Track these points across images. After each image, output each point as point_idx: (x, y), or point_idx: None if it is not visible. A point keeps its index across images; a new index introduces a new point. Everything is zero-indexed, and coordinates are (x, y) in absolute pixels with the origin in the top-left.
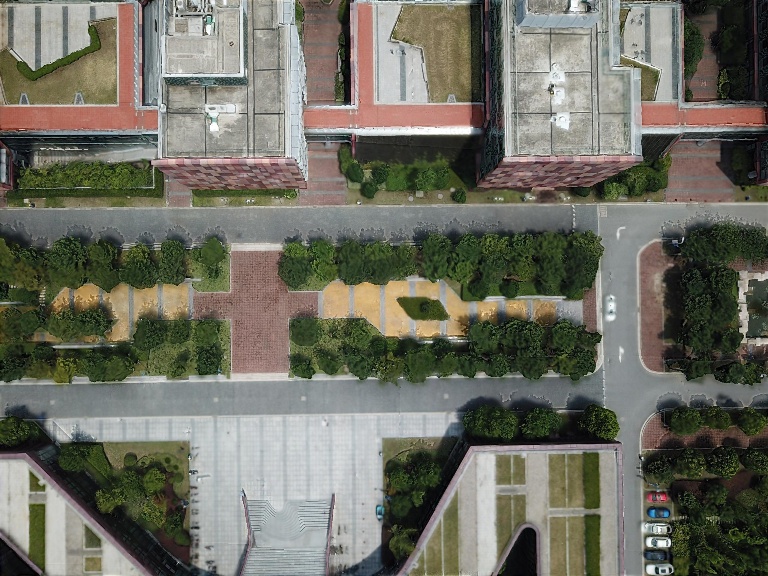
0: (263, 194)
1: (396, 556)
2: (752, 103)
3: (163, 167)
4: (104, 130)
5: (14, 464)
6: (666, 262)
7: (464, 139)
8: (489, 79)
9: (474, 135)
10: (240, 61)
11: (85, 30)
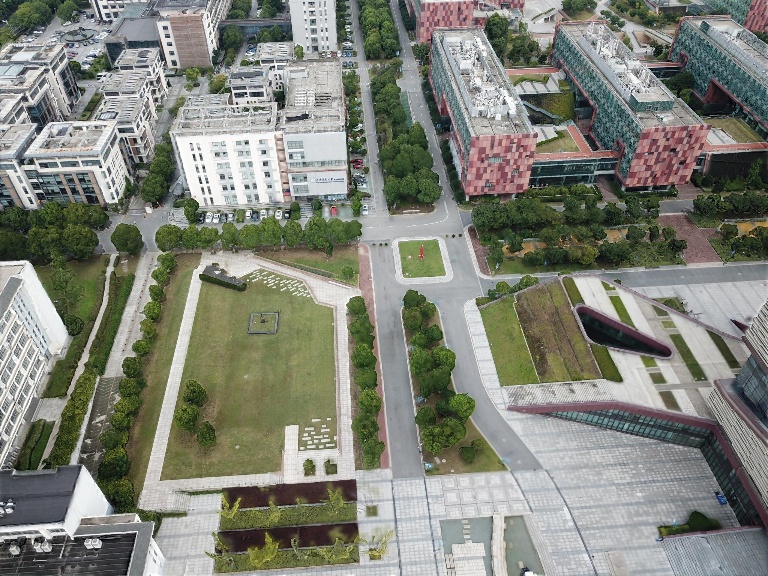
0: (660, 194)
1: None
2: None
3: (646, 133)
4: (581, 156)
5: (589, 279)
6: None
7: (765, 156)
8: (767, 126)
9: None
10: (670, 97)
11: (554, 133)
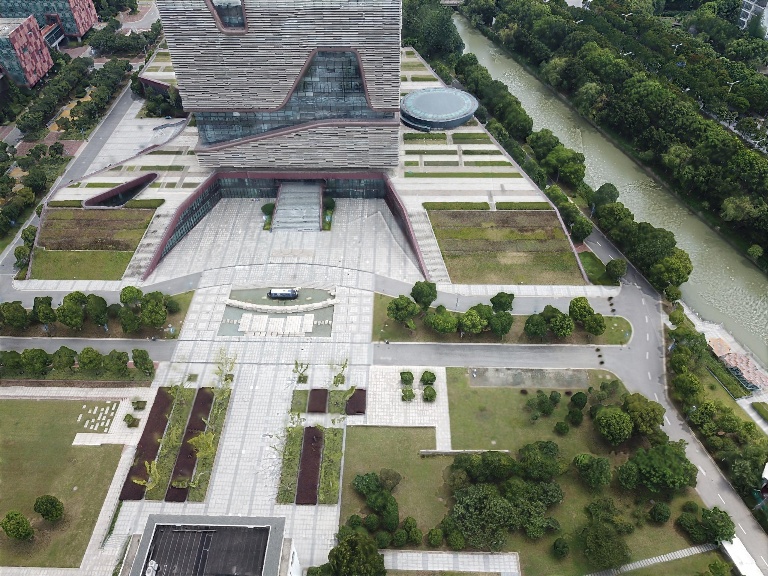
0: None
1: (176, 93)
2: (45, 27)
3: None
4: None
5: None
6: (103, 58)
7: (5, 80)
8: None
9: (5, 75)
10: None
11: None
